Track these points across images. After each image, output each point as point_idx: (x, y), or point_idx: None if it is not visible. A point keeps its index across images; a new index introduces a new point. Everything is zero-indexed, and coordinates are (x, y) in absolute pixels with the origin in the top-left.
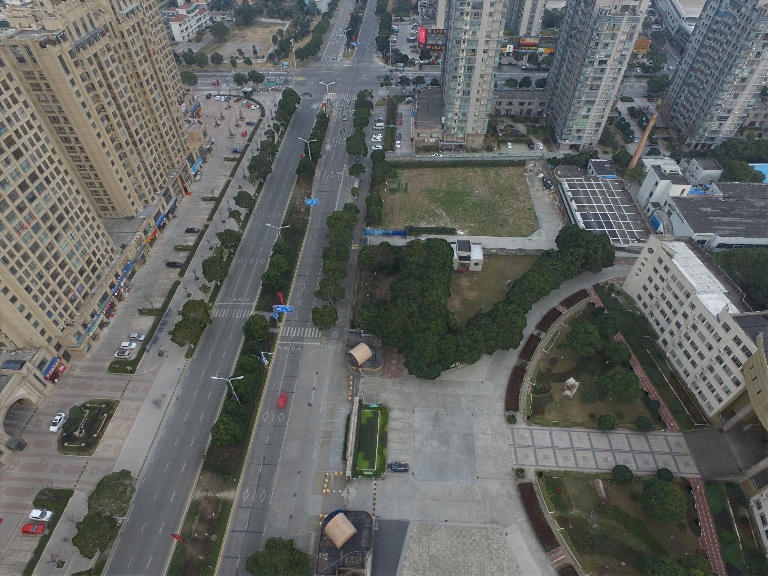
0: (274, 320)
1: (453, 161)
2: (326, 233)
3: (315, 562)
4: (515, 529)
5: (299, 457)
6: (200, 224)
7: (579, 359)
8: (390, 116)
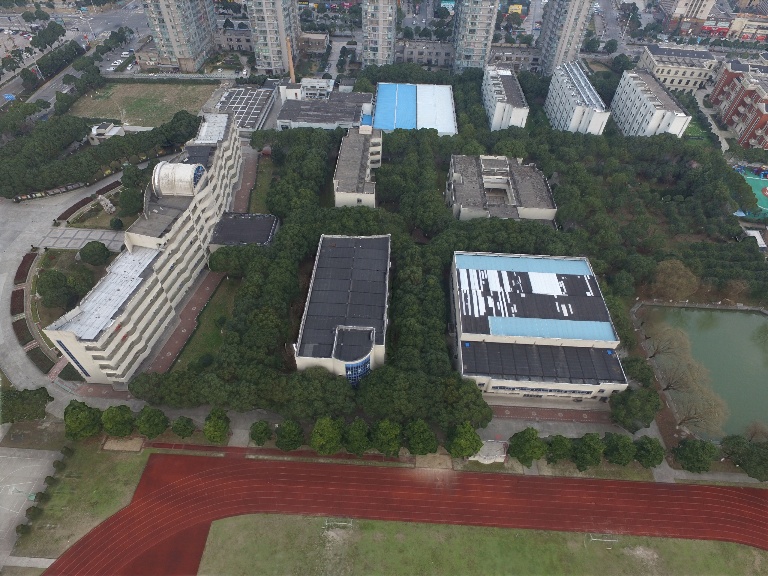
0: None
1: (160, 78)
2: (3, 116)
3: None
4: (5, 275)
5: None
6: None
7: None
8: None
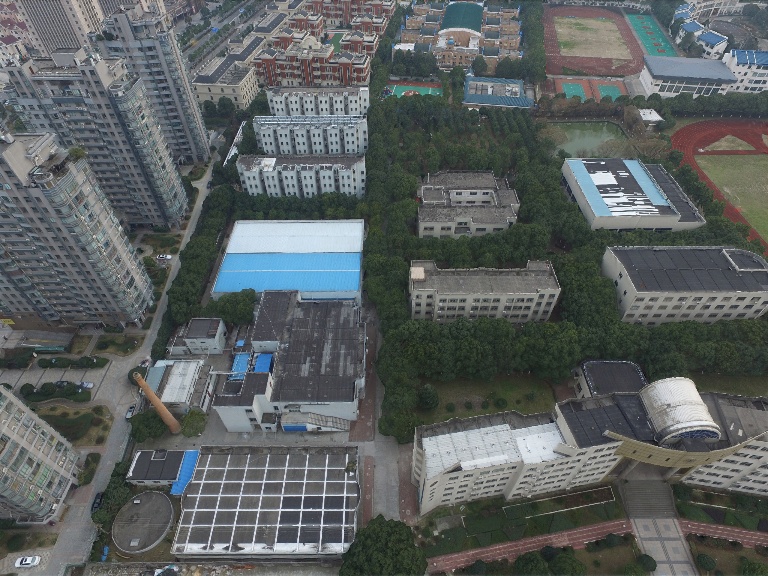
0: None
1: None
2: None
3: None
4: None
5: None
6: None
7: None
8: None
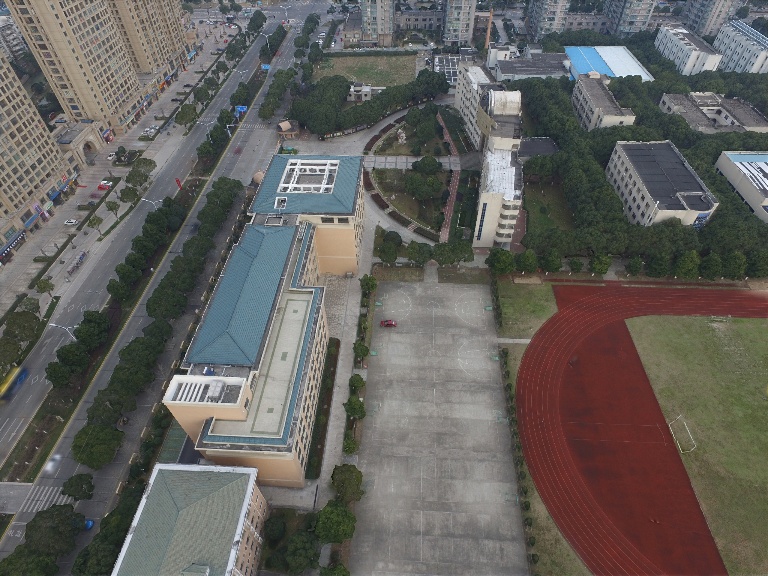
0: (237, 120)
1: (367, 51)
2: (273, 80)
3: (247, 187)
4: None
5: (245, 167)
6: (193, 84)
7: (414, 132)
8: (331, 30)
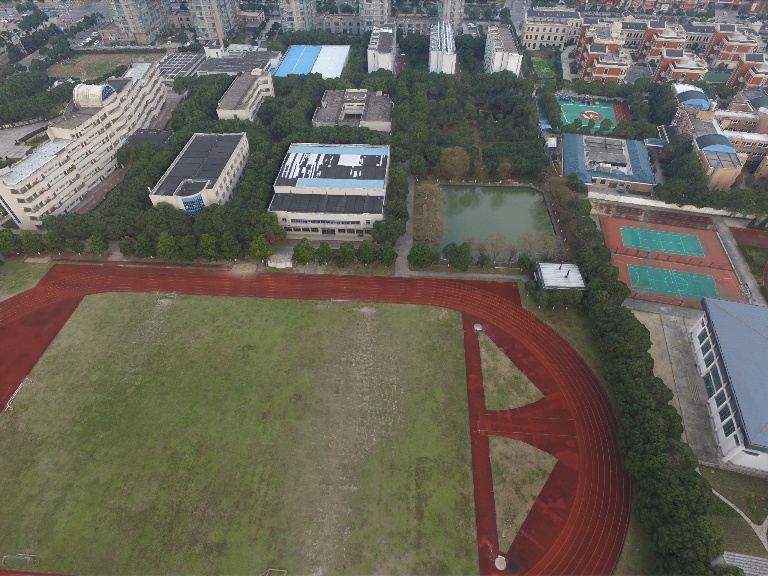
0: None
1: (117, 49)
2: None
3: None
4: None
5: None
6: None
7: None
8: None
